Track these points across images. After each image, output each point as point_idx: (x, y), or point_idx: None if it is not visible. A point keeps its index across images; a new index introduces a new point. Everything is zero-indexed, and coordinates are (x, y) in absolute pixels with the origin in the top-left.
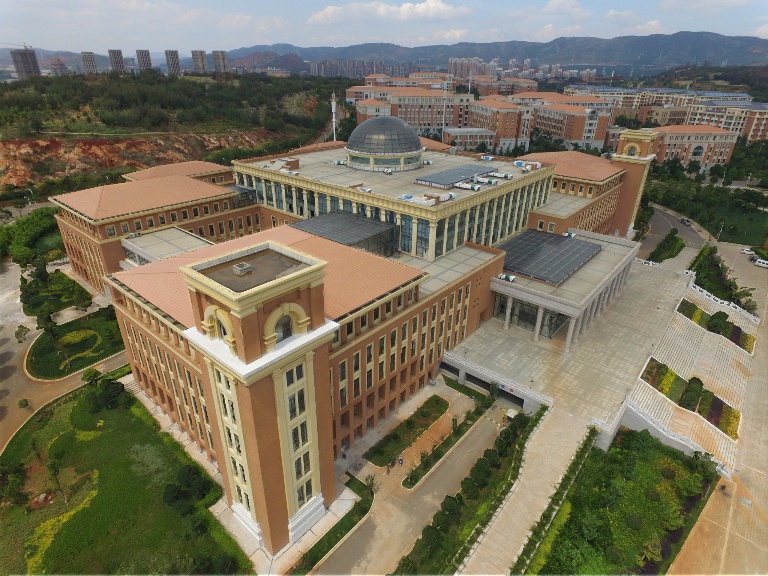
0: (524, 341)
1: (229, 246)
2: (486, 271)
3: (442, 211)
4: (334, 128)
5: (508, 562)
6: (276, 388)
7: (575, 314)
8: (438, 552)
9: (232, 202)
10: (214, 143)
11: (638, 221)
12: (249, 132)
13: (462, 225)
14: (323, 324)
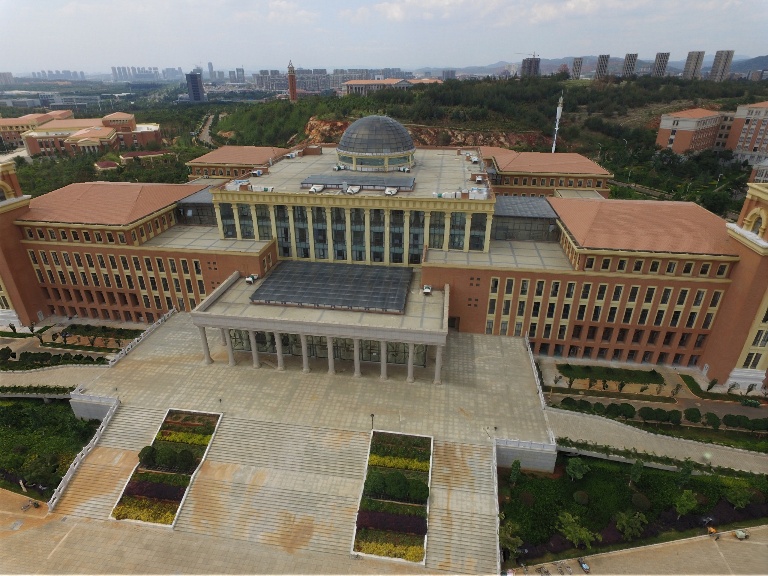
0: (219, 338)
1: None
2: (224, 260)
3: (224, 196)
4: (555, 137)
5: None
6: None
7: None
8: None
9: None
10: (458, 139)
11: None
12: (514, 134)
13: (268, 220)
14: None
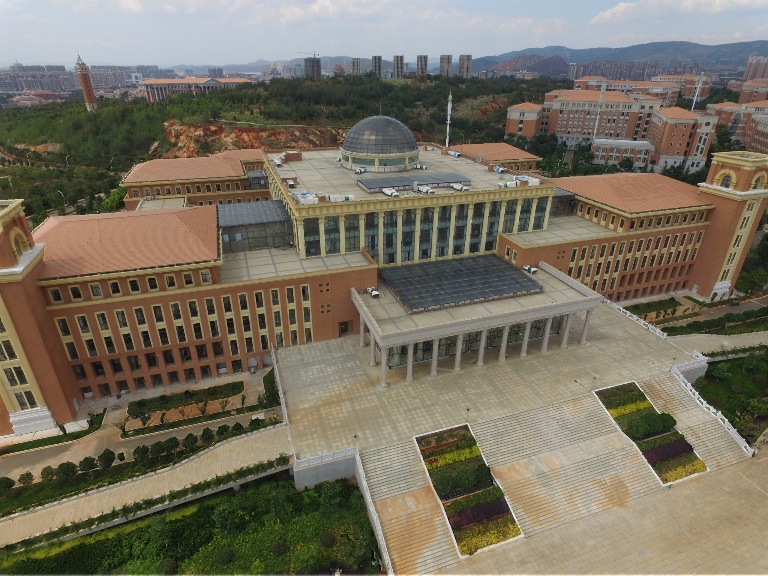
0: (360, 362)
1: None
2: (338, 279)
3: (311, 210)
4: None
5: (83, 518)
6: None
7: (380, 344)
8: (70, 488)
9: (243, 184)
10: None
11: (748, 281)
12: None
13: (356, 230)
14: (11, 267)
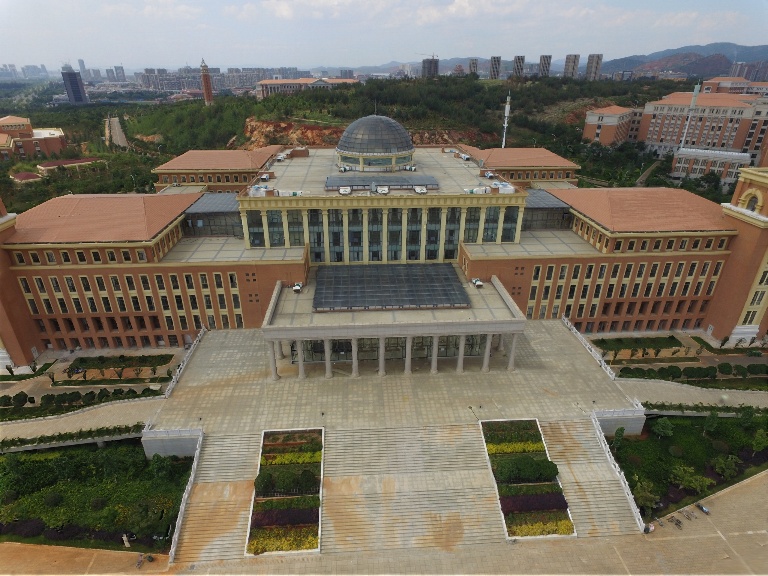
0: None
1: None
2: (264, 270)
3: (253, 203)
4: None
5: None
6: None
7: None
8: None
9: None
10: None
11: None
12: (455, 132)
13: (300, 225)
14: None
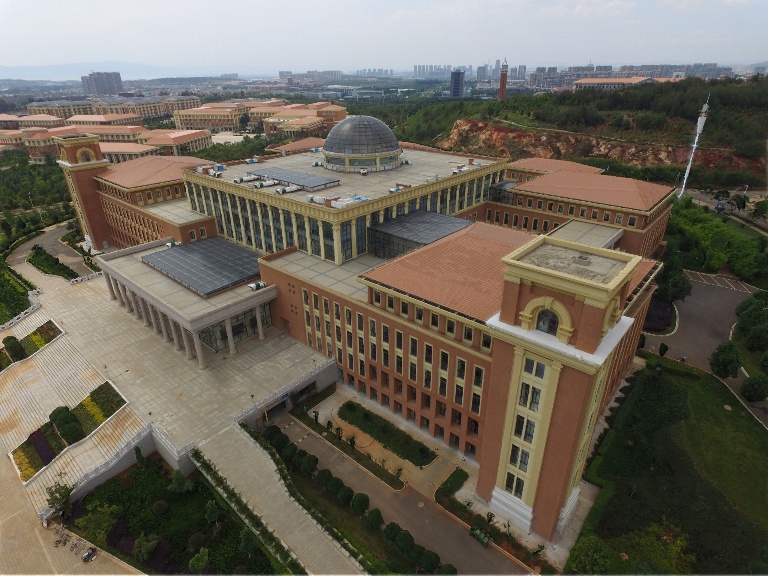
0: None
1: (201, 161)
2: (166, 226)
3: None
4: None
5: None
6: (66, 175)
7: None
8: (48, 266)
9: None
10: (600, 150)
11: None
12: (687, 150)
13: None
14: None
